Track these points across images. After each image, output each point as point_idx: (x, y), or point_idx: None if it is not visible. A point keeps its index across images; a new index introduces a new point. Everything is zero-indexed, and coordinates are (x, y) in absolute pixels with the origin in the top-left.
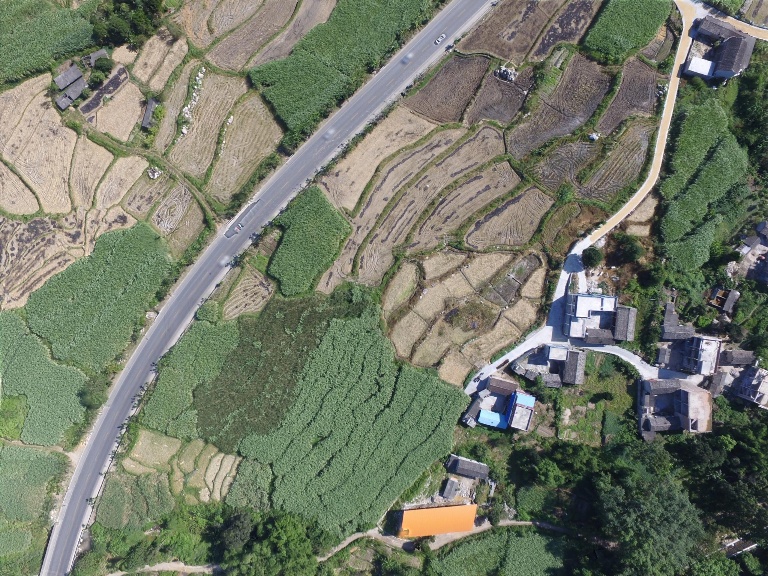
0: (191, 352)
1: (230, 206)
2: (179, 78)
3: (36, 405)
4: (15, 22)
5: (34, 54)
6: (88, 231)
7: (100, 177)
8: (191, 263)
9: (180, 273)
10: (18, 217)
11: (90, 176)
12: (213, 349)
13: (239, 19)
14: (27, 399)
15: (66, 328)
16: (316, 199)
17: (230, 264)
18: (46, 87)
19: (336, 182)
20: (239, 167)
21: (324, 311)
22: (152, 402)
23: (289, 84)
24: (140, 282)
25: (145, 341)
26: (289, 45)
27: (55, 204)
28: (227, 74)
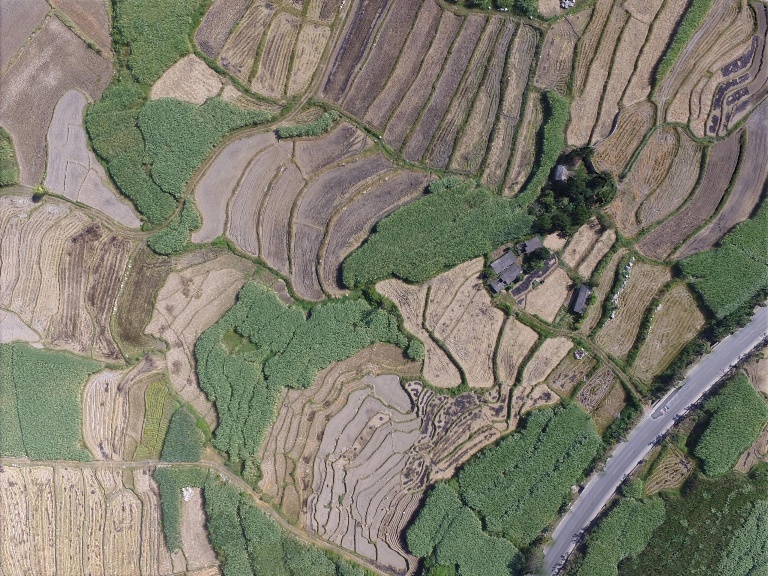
0: (619, 528)
1: (653, 388)
2: (607, 265)
3: (467, 574)
4: (457, 210)
5: (477, 242)
6: (513, 406)
7: (524, 355)
8: (618, 442)
9: (607, 451)
10: (445, 391)
11: (515, 354)
12: (641, 526)
13: (665, 211)
14: (459, 568)
15: (499, 502)
16: (744, 387)
17: (653, 443)
18: (478, 270)
19: (756, 368)
20: (662, 351)
21: (750, 493)
22: (581, 575)
23: (720, 277)
24: (572, 460)
25: (570, 514)
26: (713, 237)
27: (479, 379)
28: (654, 263)
